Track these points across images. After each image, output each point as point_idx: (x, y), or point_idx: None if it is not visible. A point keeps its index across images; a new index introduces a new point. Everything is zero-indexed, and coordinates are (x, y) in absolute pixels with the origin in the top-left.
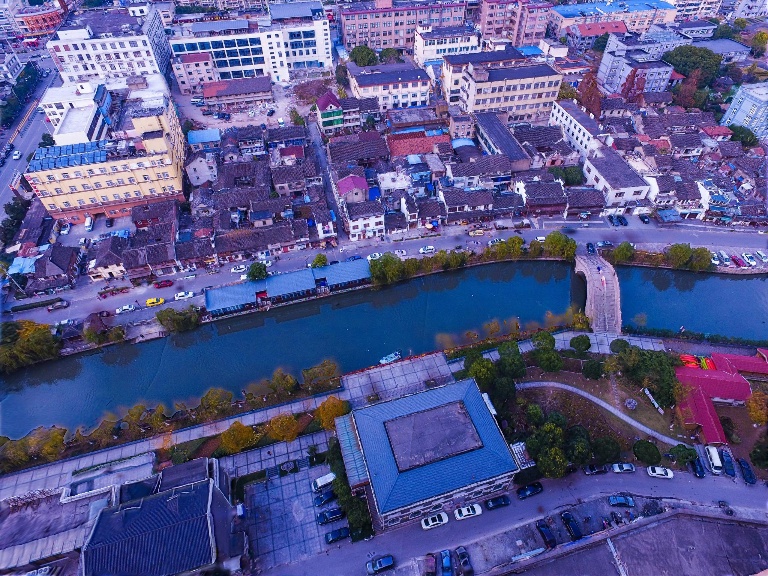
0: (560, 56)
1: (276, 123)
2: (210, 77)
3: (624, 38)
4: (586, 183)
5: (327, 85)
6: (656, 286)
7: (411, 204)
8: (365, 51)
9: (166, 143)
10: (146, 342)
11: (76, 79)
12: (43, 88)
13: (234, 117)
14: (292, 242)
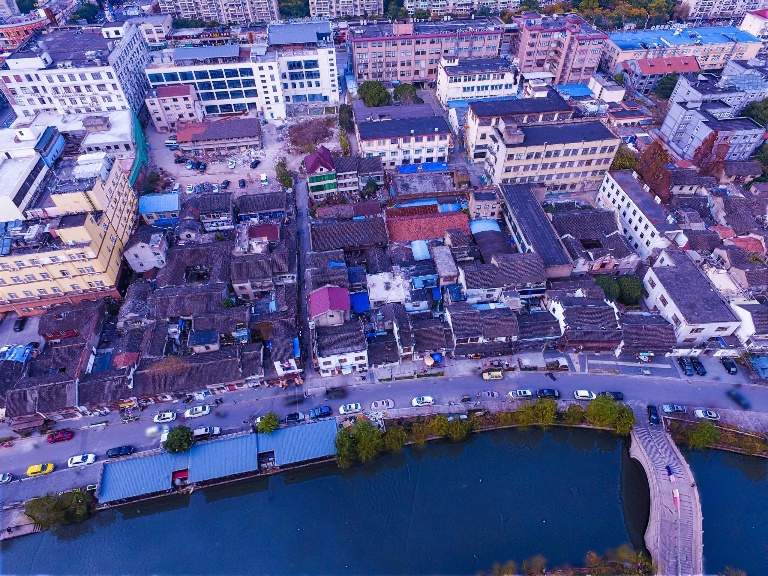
0: (614, 100)
1: (259, 179)
2: (191, 113)
3: (698, 83)
4: (647, 299)
5: (329, 127)
6: (744, 472)
7: (405, 333)
8: (376, 88)
9: (90, 231)
10: (15, 537)
11: (32, 114)
12: (5, 117)
13: (211, 167)
14: (240, 380)
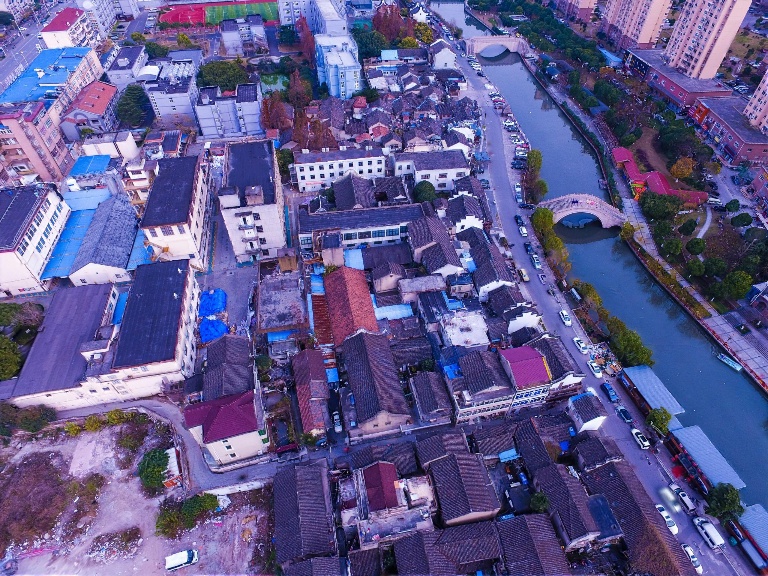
0: None
1: None
2: None
3: (166, 89)
4: None
5: (3, 466)
6: None
7: None
8: None
9: None
10: None
11: None
12: None
13: None
14: None
